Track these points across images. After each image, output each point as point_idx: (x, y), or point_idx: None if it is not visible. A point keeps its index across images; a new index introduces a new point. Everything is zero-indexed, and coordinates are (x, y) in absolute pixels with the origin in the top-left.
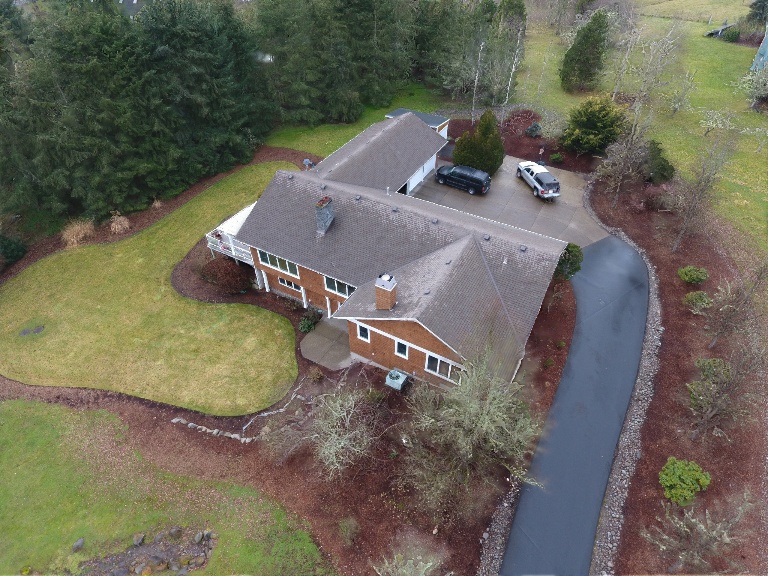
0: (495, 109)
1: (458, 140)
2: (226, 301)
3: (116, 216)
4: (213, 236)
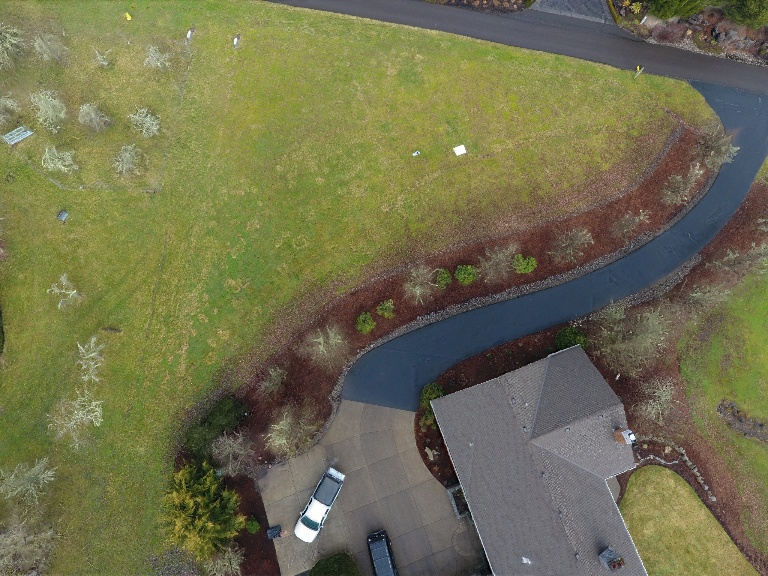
0: None
1: None
2: None
3: None
4: None
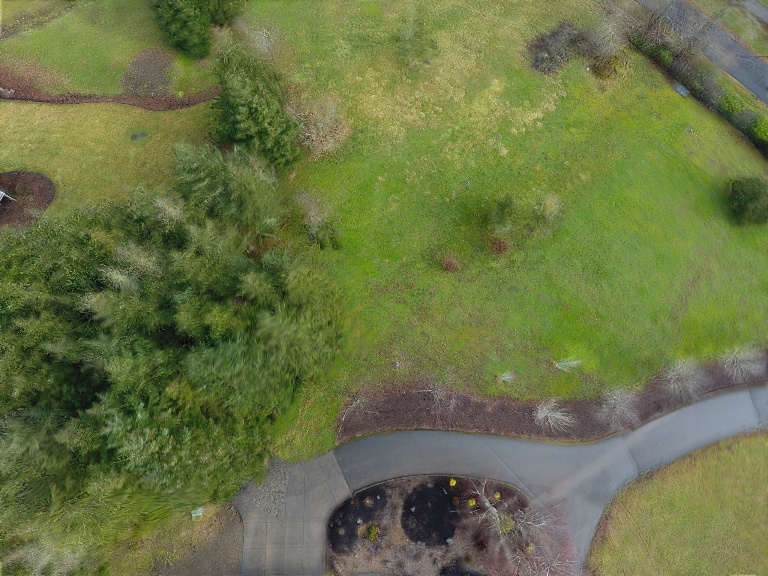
0: None
1: None
2: (7, 174)
3: None
4: None
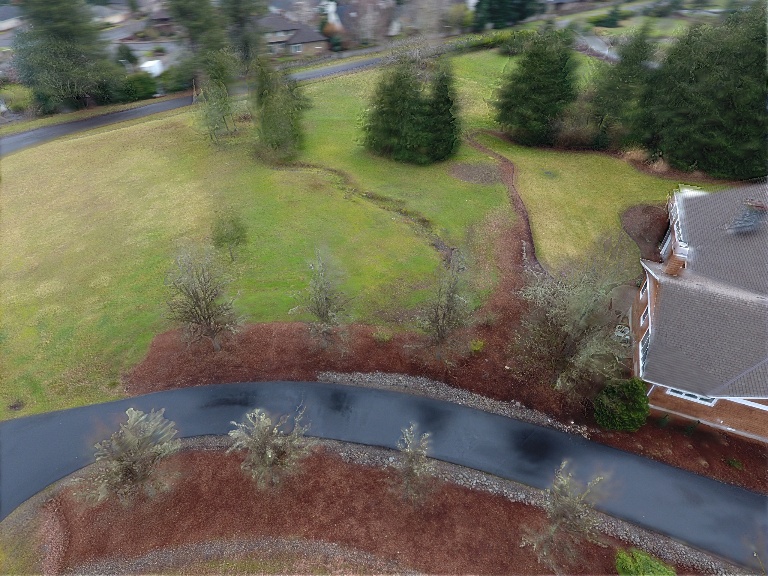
0: None
1: None
2: (631, 235)
3: (658, 154)
4: None
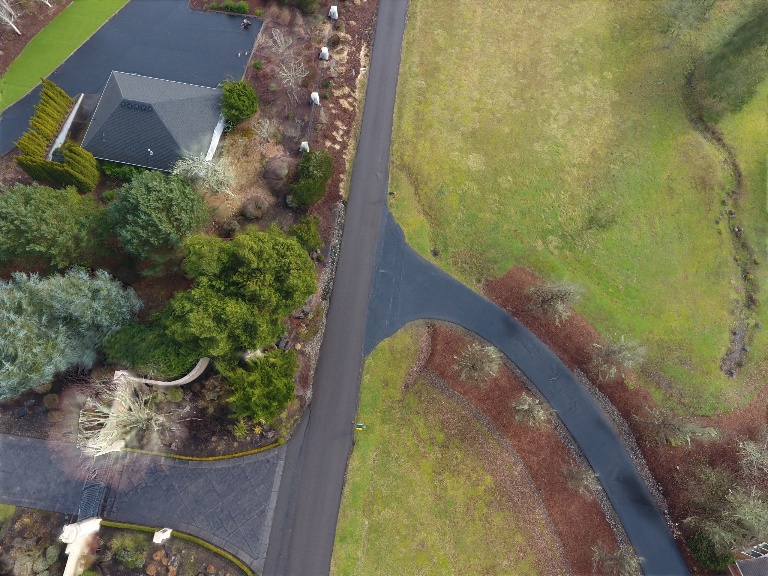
0: None
1: None
2: None
3: None
4: None
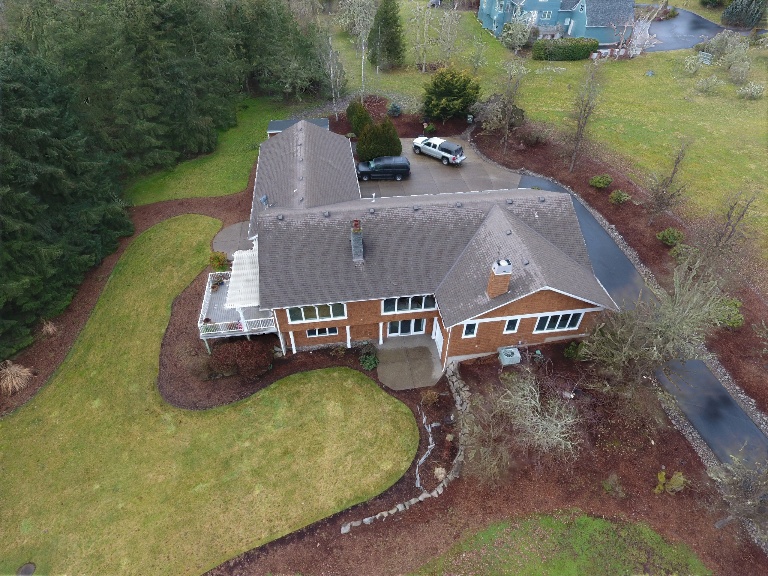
0: (340, 101)
1: (360, 135)
2: (261, 386)
3: (7, 368)
4: (204, 323)
